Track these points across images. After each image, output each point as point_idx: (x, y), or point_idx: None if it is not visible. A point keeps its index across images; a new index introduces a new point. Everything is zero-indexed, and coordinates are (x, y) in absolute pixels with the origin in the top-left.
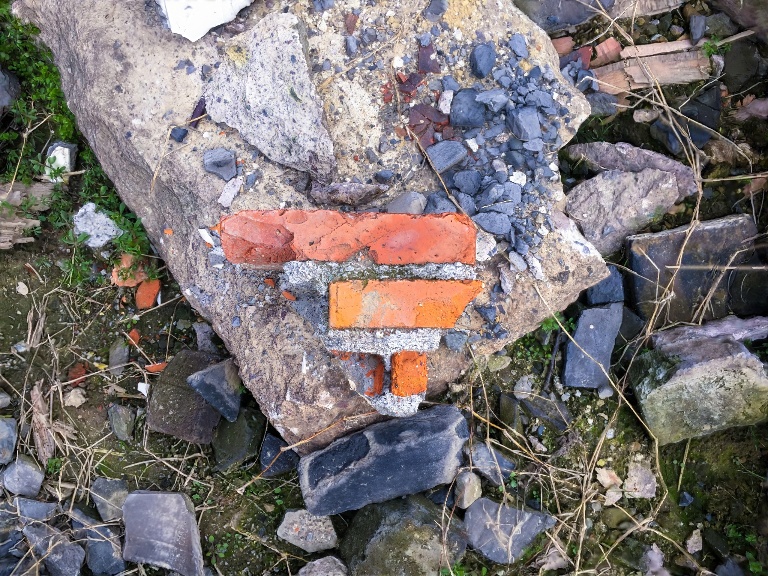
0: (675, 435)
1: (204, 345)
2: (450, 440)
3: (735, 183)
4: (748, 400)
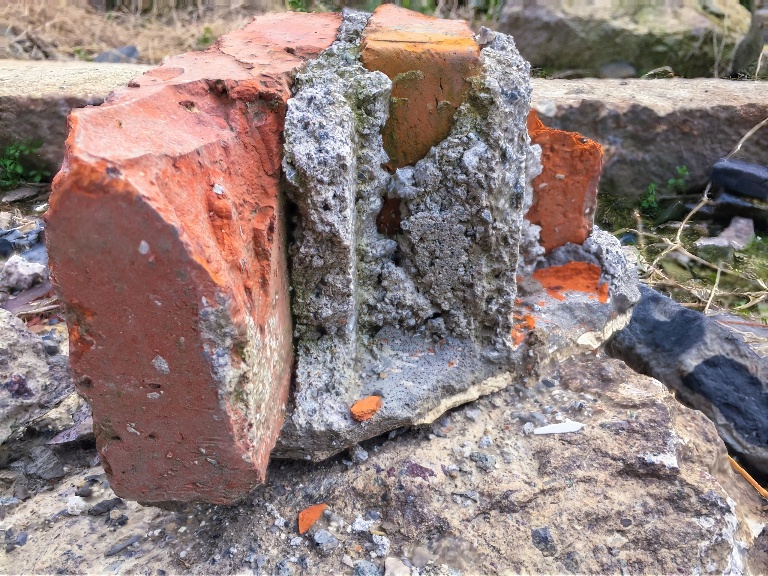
0: None
1: None
2: None
3: None
4: None
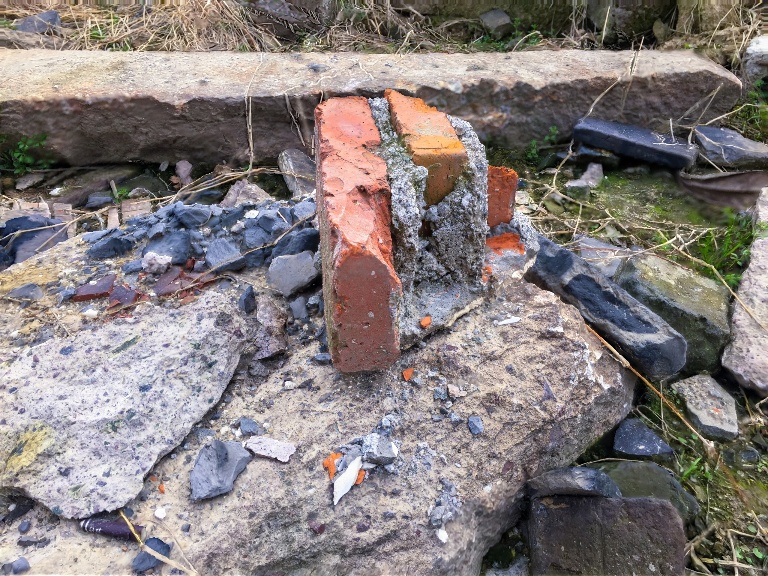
0: None
1: (519, 575)
2: None
3: (249, 178)
4: None
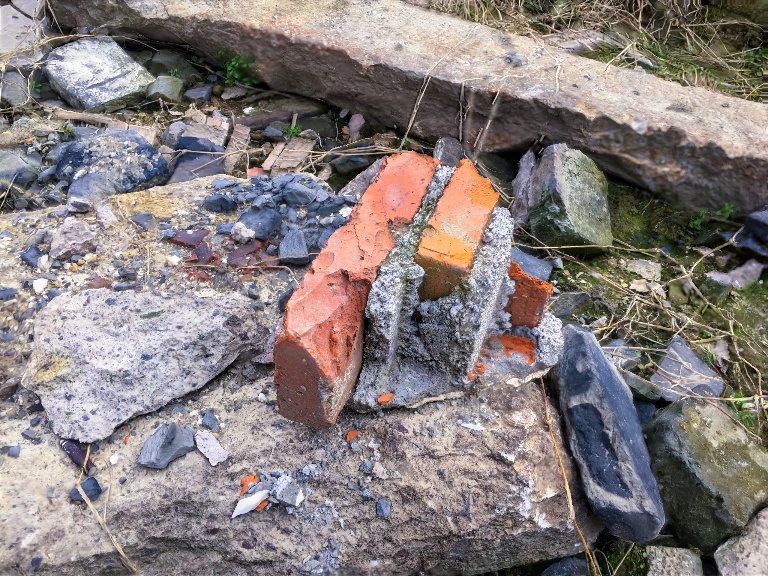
0: (607, 234)
1: None
2: (592, 341)
3: None
4: (589, 171)
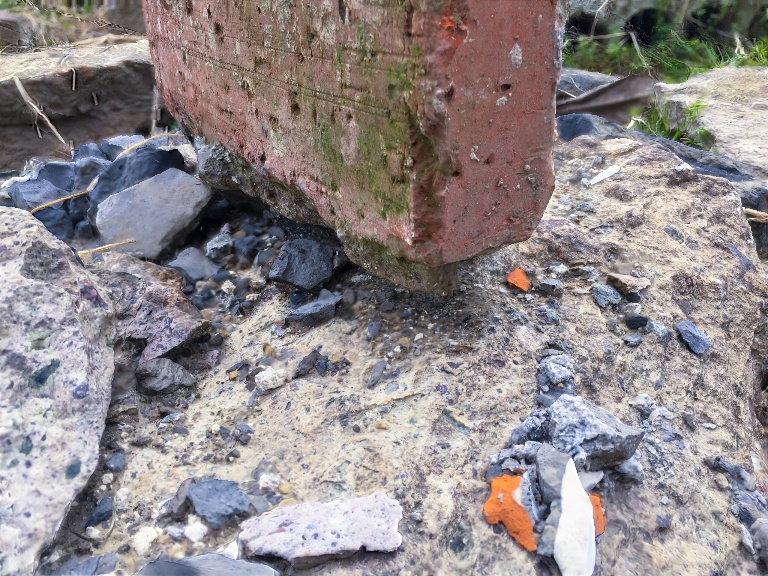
0: None
1: None
2: None
3: None
4: None
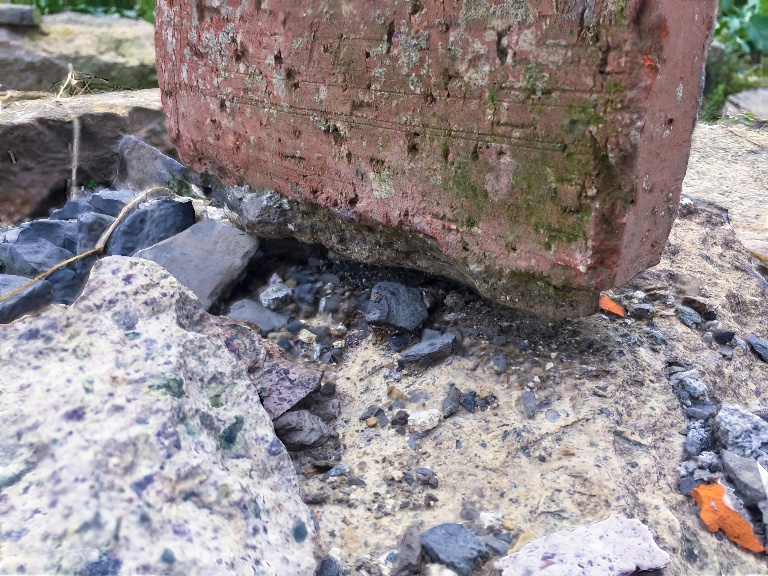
0: None
1: None
2: None
3: None
4: None
